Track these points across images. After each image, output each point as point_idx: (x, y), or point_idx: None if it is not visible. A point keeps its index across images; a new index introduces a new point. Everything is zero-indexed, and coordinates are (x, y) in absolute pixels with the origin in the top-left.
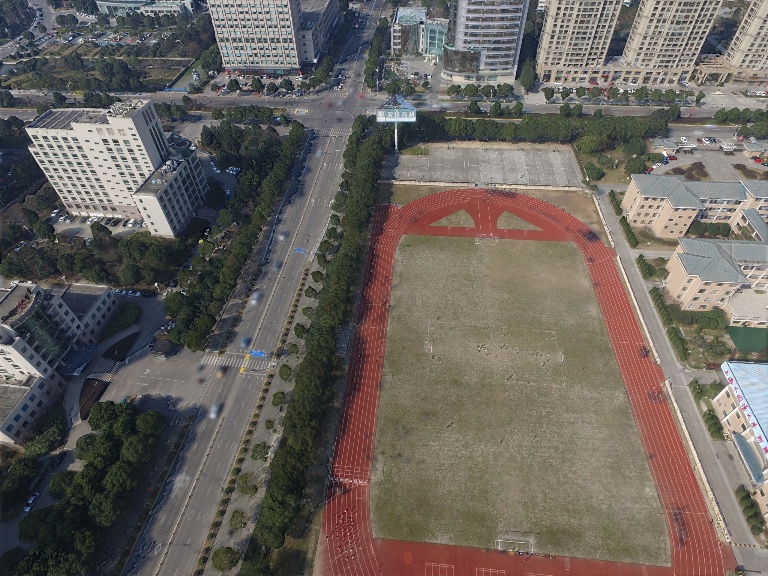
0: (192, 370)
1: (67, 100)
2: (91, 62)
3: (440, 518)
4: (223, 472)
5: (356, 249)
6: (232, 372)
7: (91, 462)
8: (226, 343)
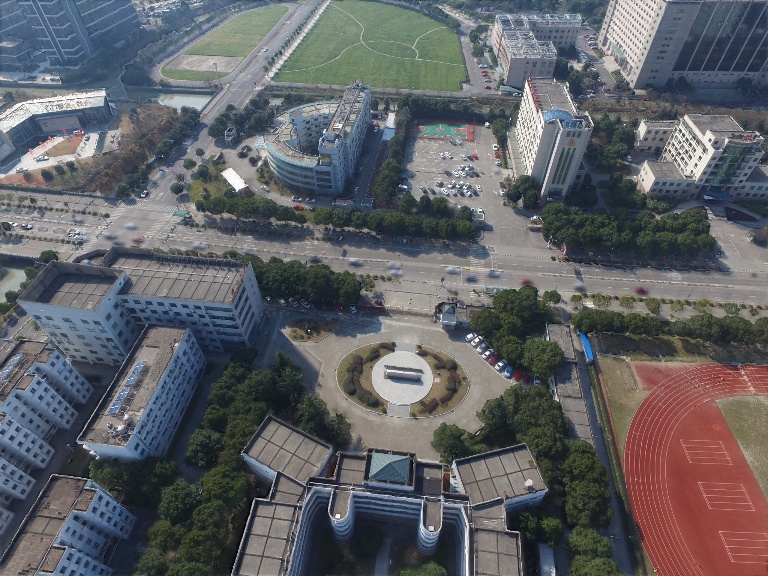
0: (754, 259)
1: None
2: None
3: (764, 454)
4: (697, 297)
5: None
6: None
7: (666, 221)
8: None
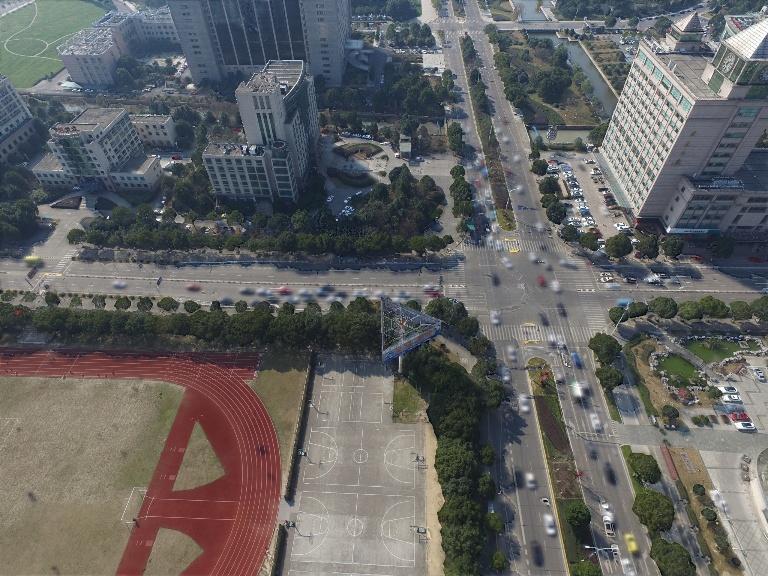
0: (66, 246)
1: (488, 81)
2: (571, 67)
3: None
4: None
5: (137, 328)
6: (48, 269)
7: None
8: (82, 259)
